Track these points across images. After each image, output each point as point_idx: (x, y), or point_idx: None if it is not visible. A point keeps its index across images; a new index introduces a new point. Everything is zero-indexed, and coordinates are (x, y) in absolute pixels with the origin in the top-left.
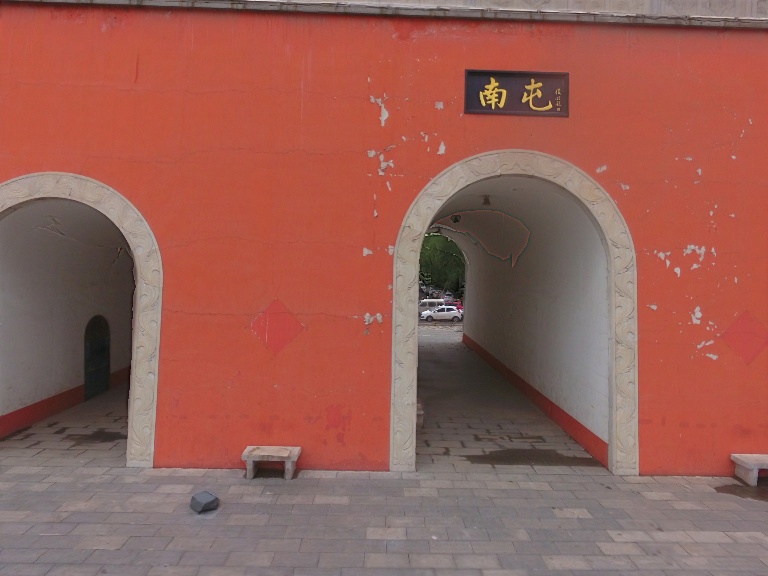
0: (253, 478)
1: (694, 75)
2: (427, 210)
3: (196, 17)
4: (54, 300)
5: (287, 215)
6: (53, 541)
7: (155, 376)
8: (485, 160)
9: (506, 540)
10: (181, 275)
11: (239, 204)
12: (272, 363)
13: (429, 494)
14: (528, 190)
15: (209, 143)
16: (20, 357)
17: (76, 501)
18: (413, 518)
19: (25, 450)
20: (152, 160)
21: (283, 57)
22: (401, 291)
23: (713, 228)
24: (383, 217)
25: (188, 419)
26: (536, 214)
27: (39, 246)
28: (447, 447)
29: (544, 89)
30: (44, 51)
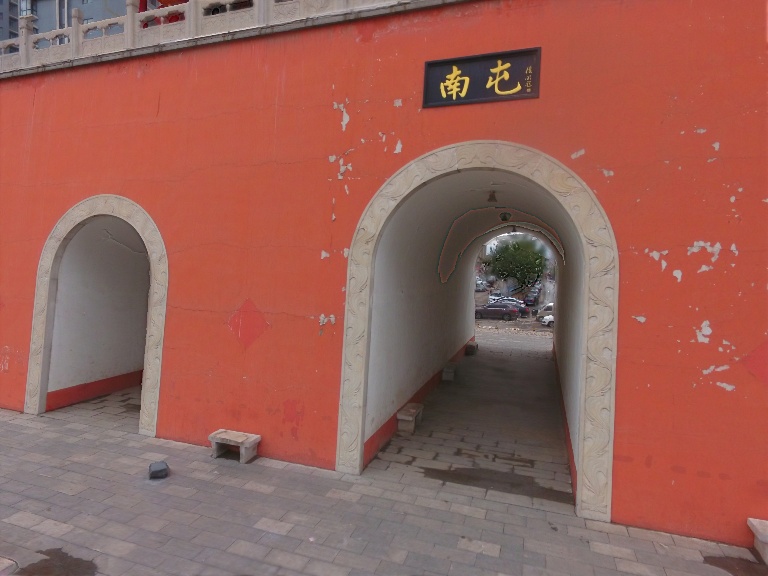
0: (216, 457)
1: (714, 22)
2: (381, 211)
3: (199, 53)
4: (133, 295)
5: (260, 222)
6: (42, 481)
7: (160, 361)
8: (442, 155)
9: (377, 557)
10: (181, 276)
11: (224, 213)
12: (243, 356)
13: (349, 498)
14: (511, 183)
15: (205, 161)
16: (102, 339)
17: (83, 454)
18: (311, 517)
19: (90, 411)
20: (165, 180)
21: (262, 77)
22: (353, 293)
23: (734, 218)
24: (341, 220)
25: (181, 400)
26: (543, 209)
27: (116, 253)
28: (416, 456)
29: (512, 70)
30: (102, 100)
